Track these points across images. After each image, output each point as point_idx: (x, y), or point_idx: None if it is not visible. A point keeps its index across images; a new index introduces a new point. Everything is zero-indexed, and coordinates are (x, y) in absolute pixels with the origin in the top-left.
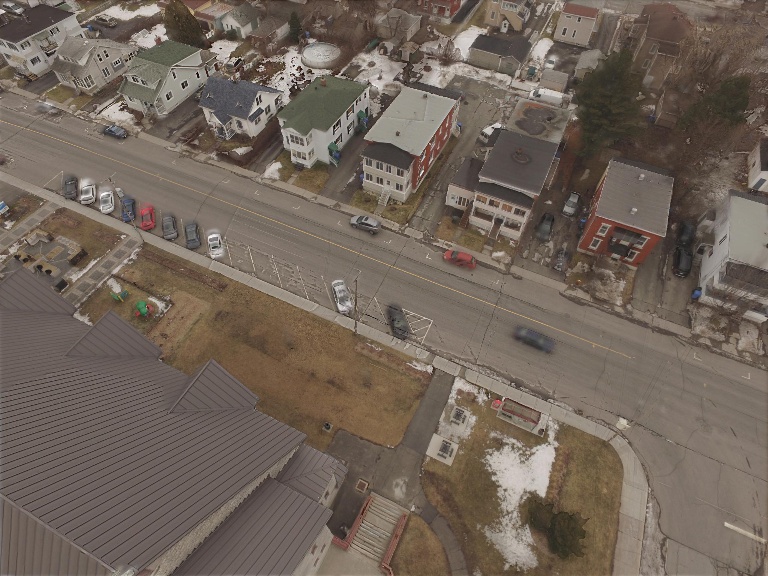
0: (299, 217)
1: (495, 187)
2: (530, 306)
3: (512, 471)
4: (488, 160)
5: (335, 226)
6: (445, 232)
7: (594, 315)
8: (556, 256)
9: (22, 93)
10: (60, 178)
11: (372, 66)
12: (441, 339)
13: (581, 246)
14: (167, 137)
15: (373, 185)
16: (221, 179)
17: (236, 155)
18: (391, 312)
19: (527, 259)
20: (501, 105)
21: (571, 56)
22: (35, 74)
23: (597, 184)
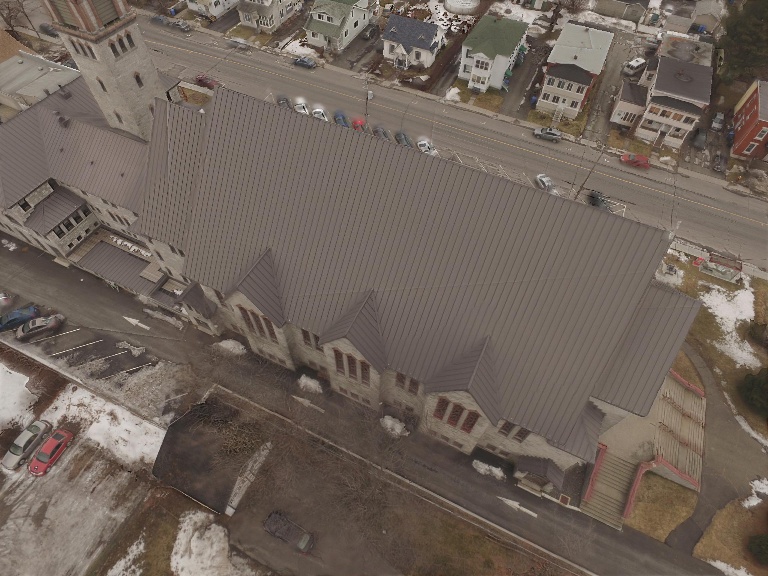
0: (488, 130)
1: (668, 99)
2: (702, 196)
3: (723, 306)
4: (658, 78)
5: (521, 137)
6: (615, 142)
7: (756, 203)
8: (713, 161)
9: (207, 32)
10: (271, 98)
11: (509, 13)
12: (637, 218)
13: (735, 152)
14: (350, 68)
15: (548, 104)
16: (410, 101)
17: (421, 80)
18: (590, 199)
19: (690, 163)
20: (633, 46)
21: (682, 7)
22: (215, 16)
23: (734, 107)
